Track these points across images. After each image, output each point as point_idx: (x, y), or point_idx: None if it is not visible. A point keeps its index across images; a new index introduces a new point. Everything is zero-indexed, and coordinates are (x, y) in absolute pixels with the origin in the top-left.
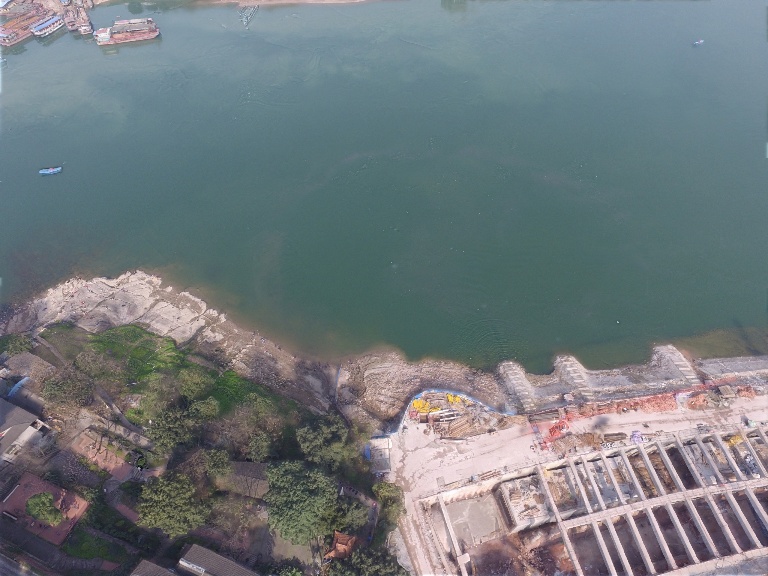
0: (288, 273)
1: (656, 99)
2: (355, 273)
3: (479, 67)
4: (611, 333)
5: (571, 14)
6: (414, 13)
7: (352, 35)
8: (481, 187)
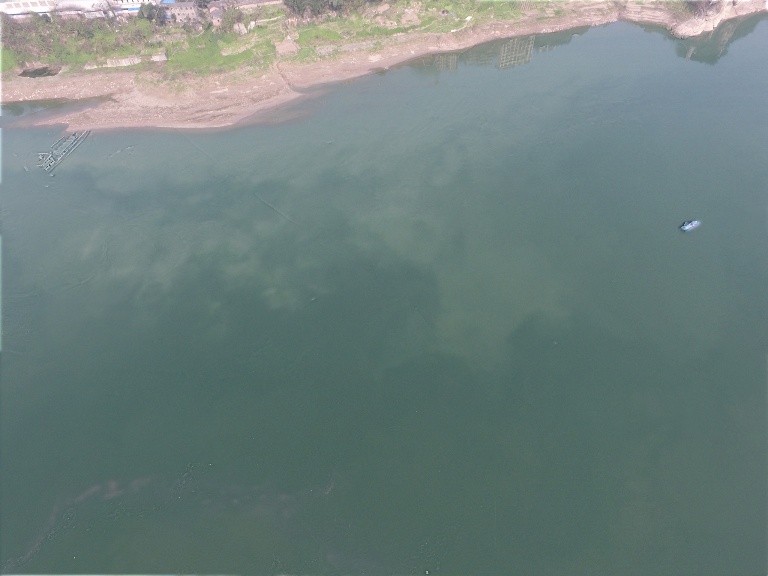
0: None
1: (605, 361)
2: None
3: (341, 269)
4: None
5: (510, 155)
6: (292, 147)
7: (193, 187)
8: None
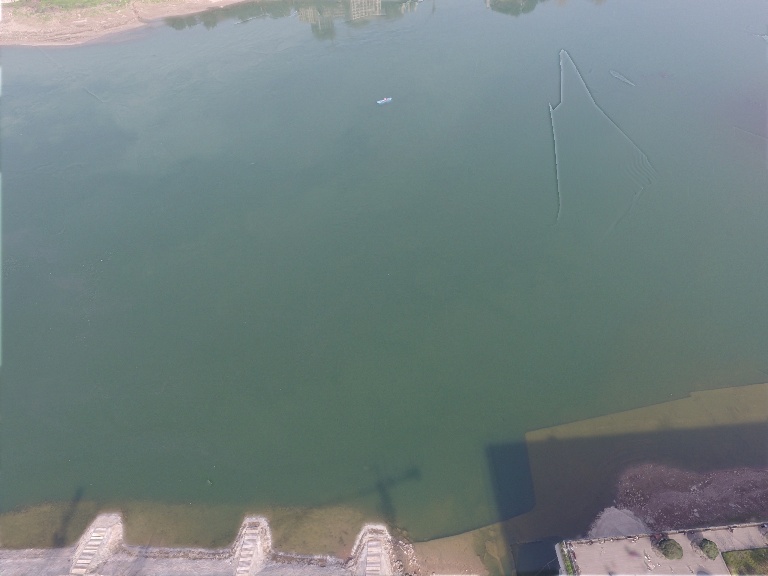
0: None
1: (279, 171)
2: None
3: (124, 127)
4: None
5: (287, 62)
6: (124, 58)
7: (38, 83)
8: None
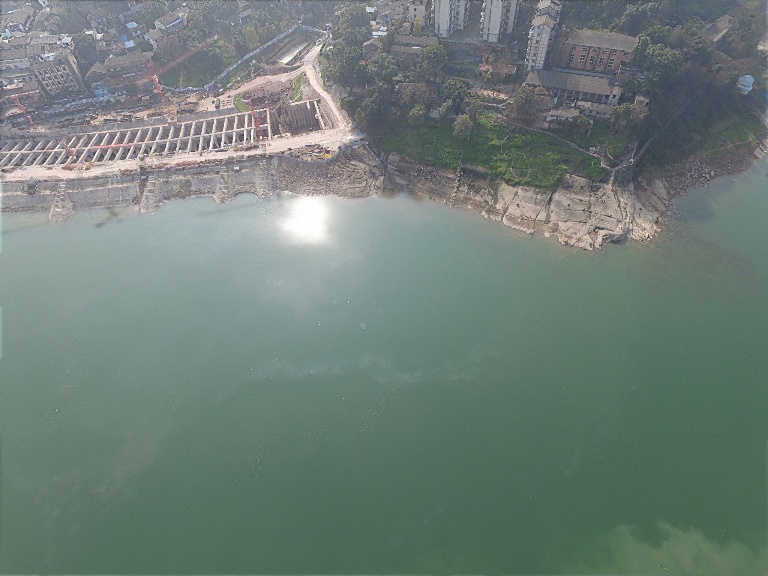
0: (441, 250)
1: None
2: (377, 254)
3: None
4: (179, 219)
5: None
6: None
7: None
8: (216, 372)
